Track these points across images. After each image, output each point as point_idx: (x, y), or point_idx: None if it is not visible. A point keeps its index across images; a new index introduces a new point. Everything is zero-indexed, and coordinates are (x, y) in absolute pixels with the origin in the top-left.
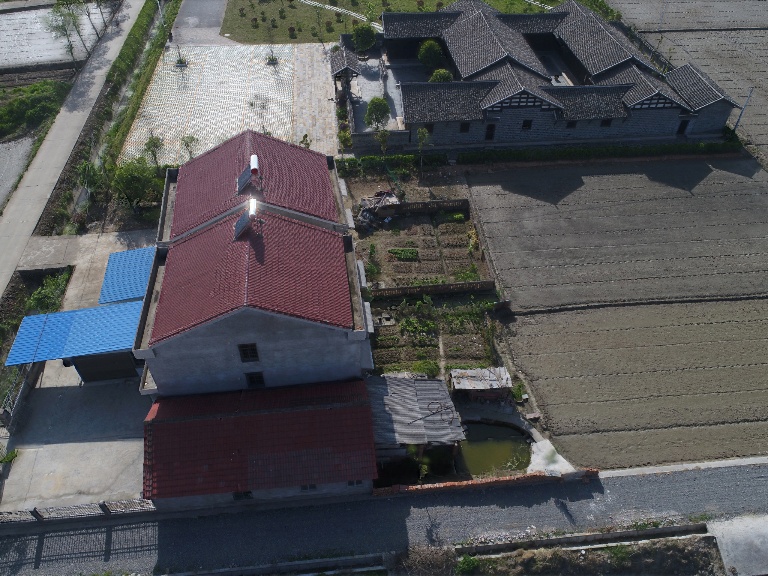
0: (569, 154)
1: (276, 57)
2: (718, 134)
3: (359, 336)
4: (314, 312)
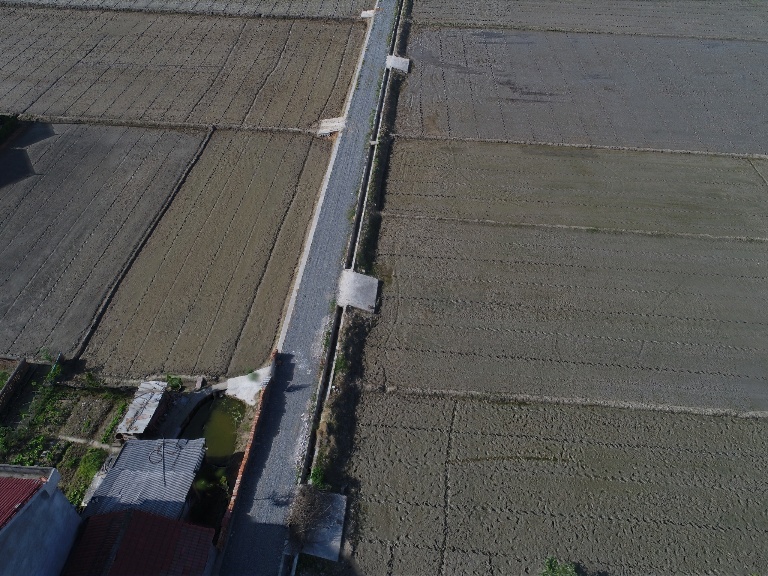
0: None
1: None
2: None
3: (54, 481)
4: None
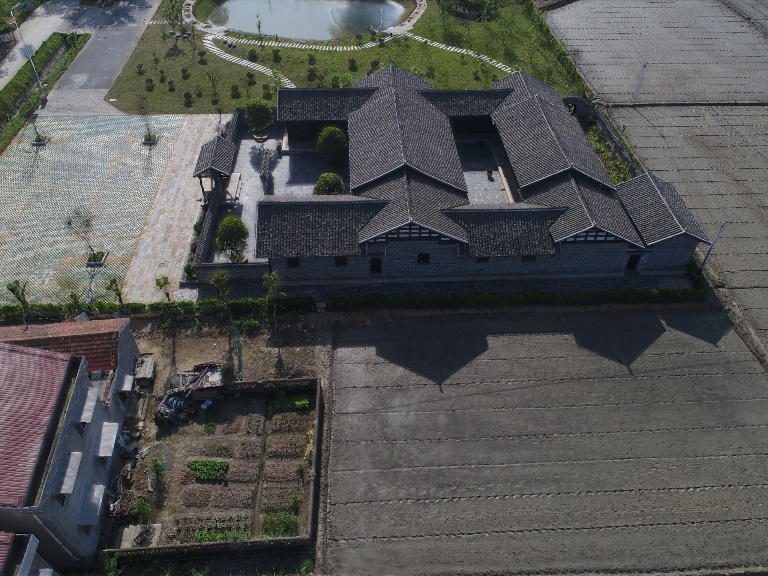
0: (475, 301)
1: (156, 134)
2: (681, 271)
3: None
4: None
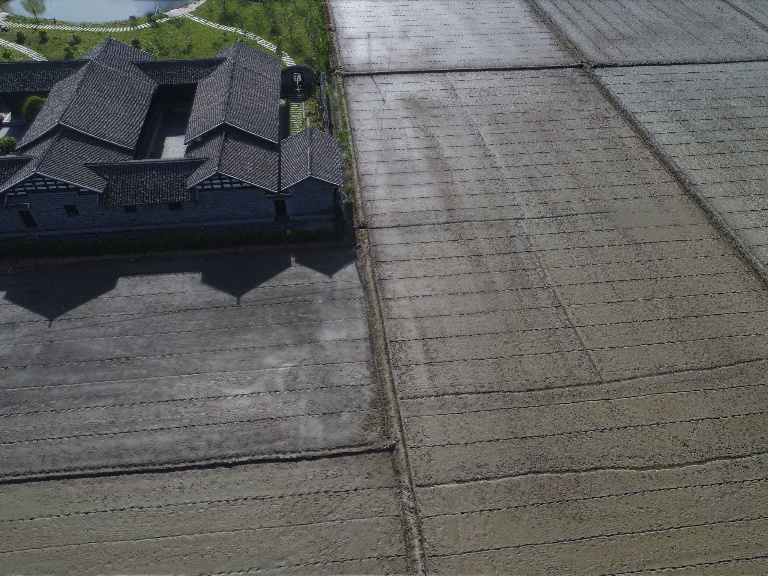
0: (117, 247)
1: None
2: (329, 214)
3: None
4: None
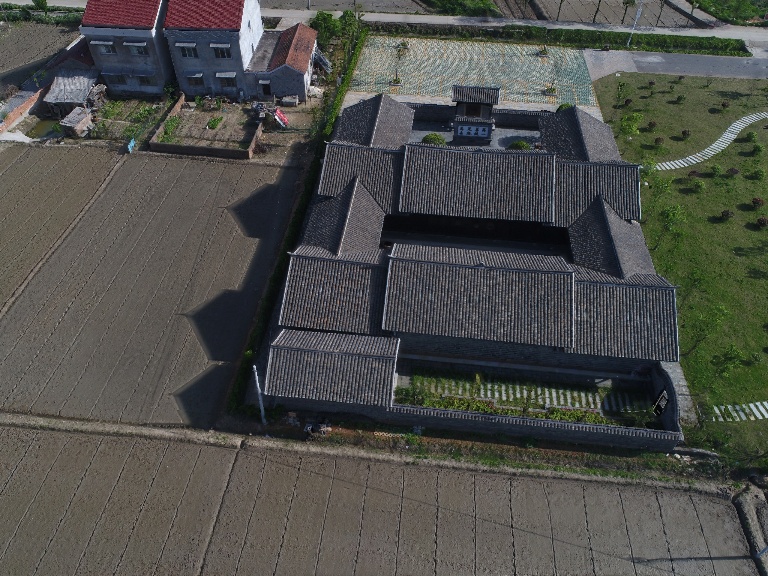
0: None
1: None
2: None
3: None
4: (91, 7)
